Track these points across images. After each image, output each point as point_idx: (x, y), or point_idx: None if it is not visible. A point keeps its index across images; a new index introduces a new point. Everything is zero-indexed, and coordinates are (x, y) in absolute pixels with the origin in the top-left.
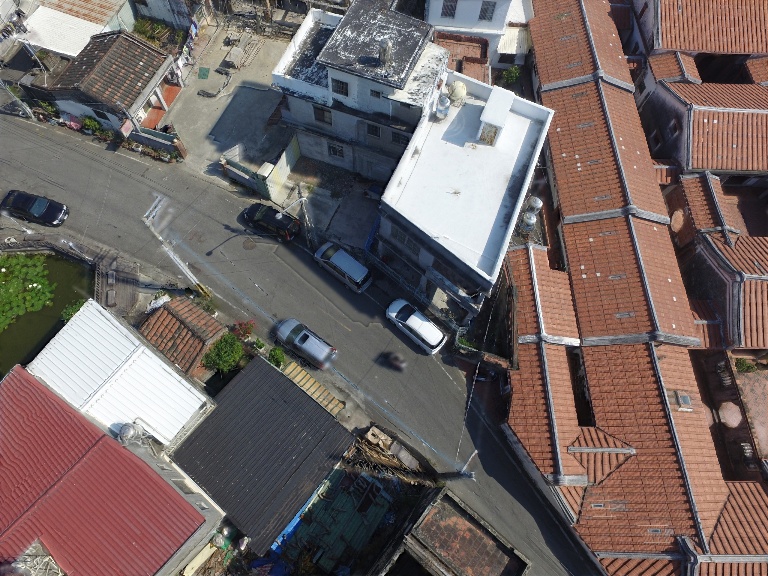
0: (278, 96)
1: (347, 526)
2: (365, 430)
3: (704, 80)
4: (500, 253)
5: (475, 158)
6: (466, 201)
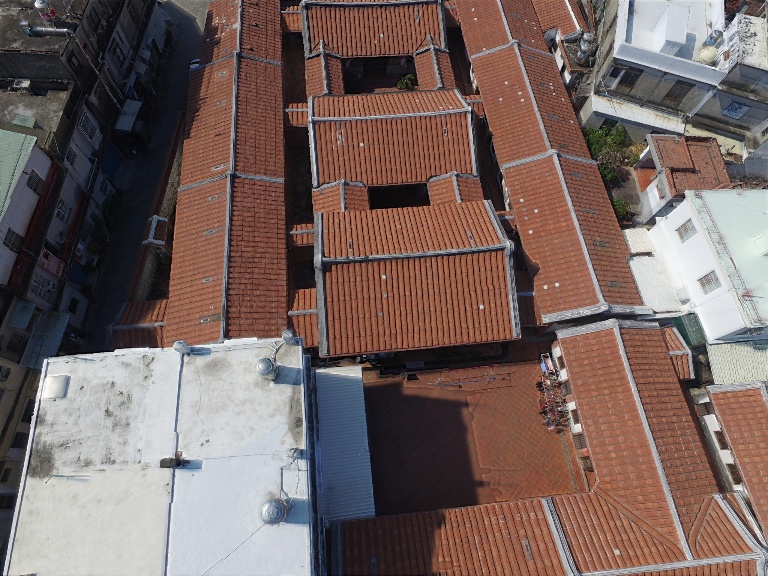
0: None
1: None
2: None
3: None
4: None
5: None
6: None
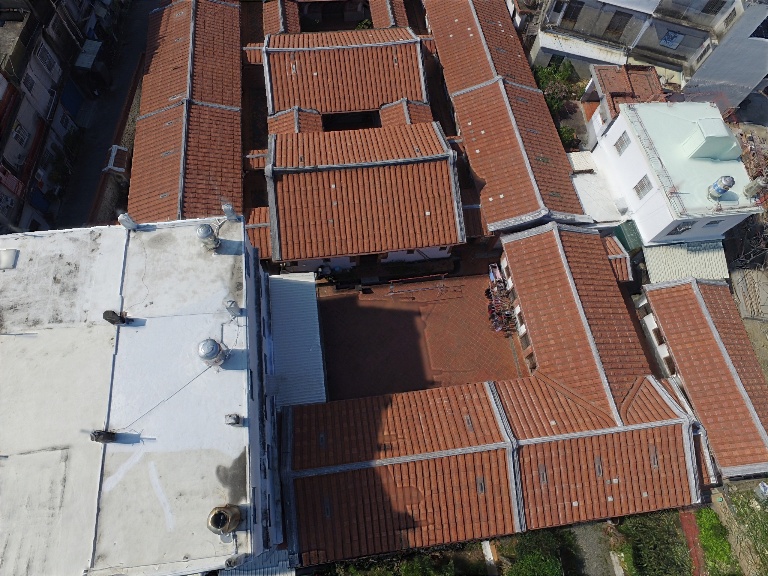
0: (764, 117)
1: None
2: None
3: None
4: None
5: None
6: None
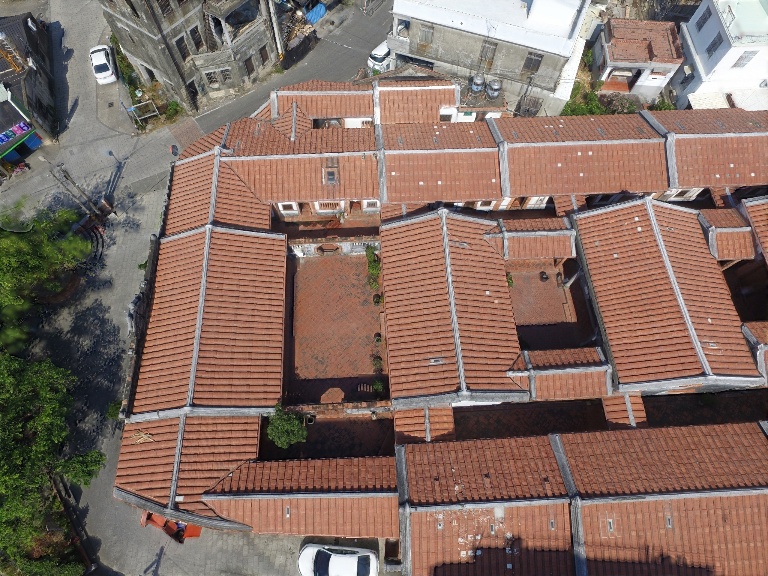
0: None
1: None
2: None
3: None
4: (420, 2)
5: (512, 7)
6: (468, 1)
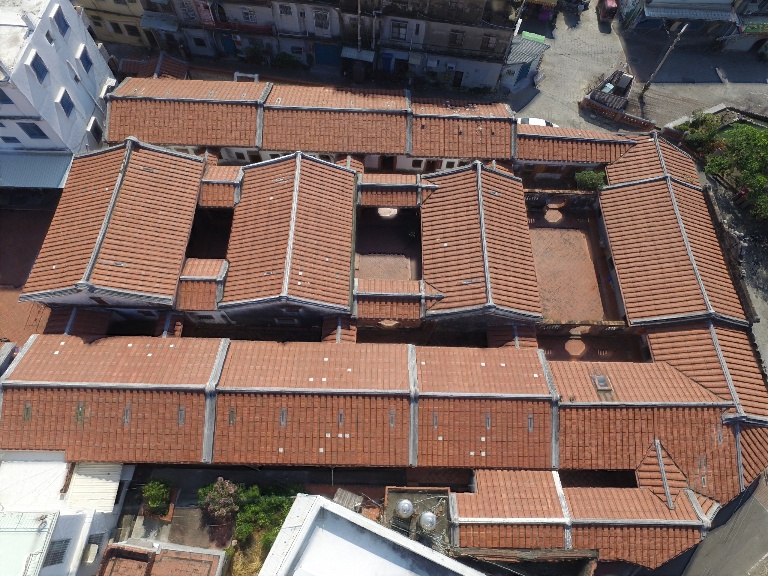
0: None
1: None
2: None
3: (194, 239)
4: None
5: None
6: None
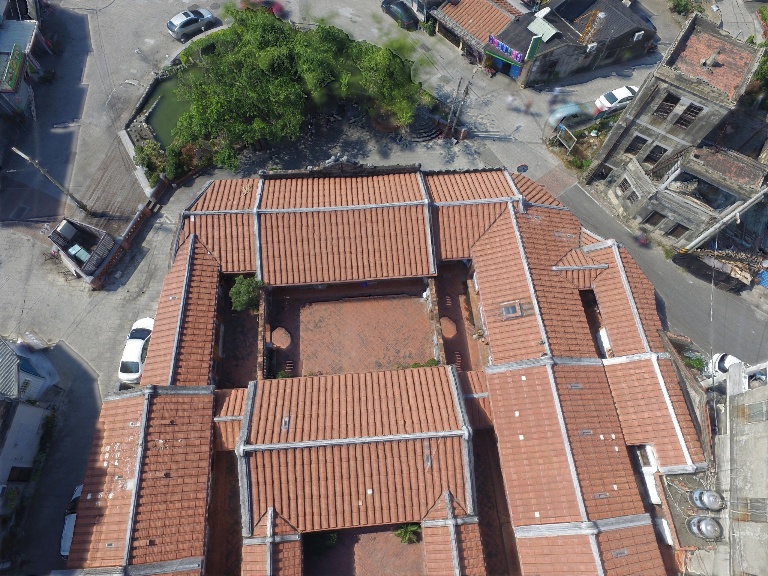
0: None
1: (746, 214)
2: (743, 289)
3: None
4: None
5: None
6: None
